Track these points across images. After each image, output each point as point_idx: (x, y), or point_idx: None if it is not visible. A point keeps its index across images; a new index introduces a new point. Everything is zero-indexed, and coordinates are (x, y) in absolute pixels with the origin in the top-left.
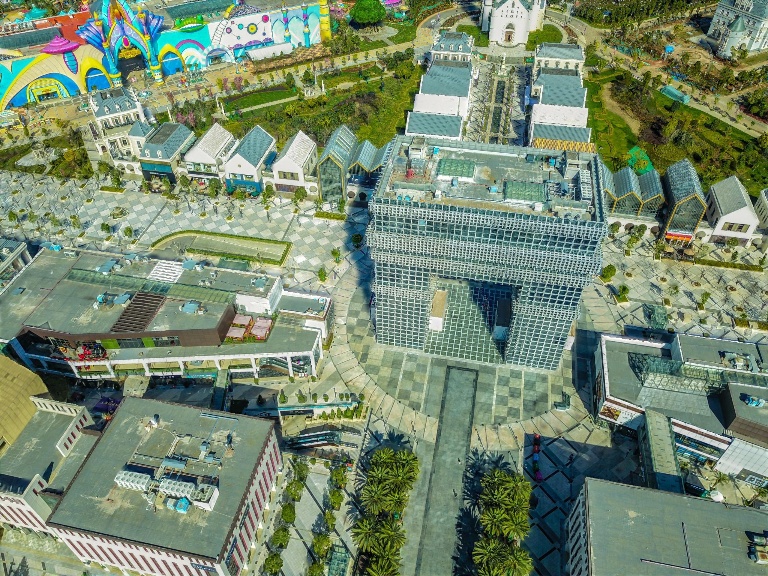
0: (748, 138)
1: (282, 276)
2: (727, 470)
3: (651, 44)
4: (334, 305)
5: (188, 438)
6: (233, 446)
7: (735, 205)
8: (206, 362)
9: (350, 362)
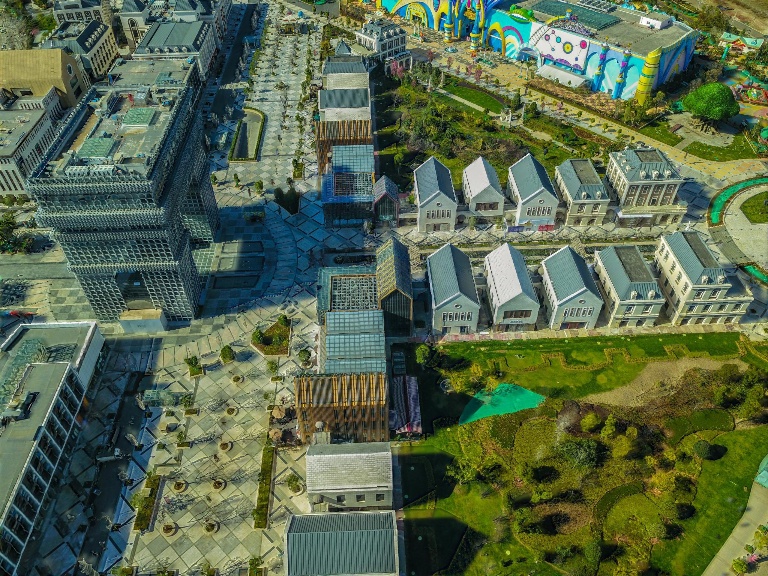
0: None
1: None
2: None
3: None
4: None
5: (6, 132)
6: None
7: (320, 450)
8: None
9: None
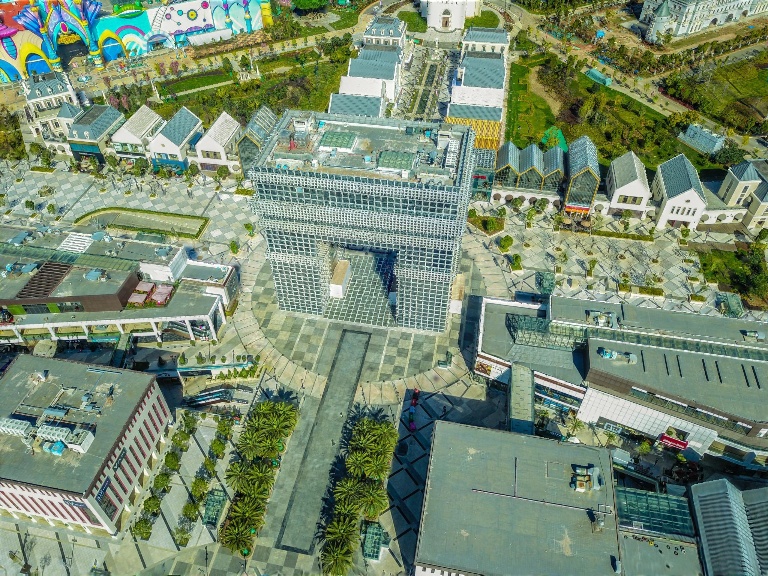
0: (662, 118)
1: (194, 248)
2: (587, 419)
3: (584, 29)
4: (243, 275)
5: (72, 390)
6: (114, 397)
7: (628, 178)
8: (111, 327)
9: (252, 327)
